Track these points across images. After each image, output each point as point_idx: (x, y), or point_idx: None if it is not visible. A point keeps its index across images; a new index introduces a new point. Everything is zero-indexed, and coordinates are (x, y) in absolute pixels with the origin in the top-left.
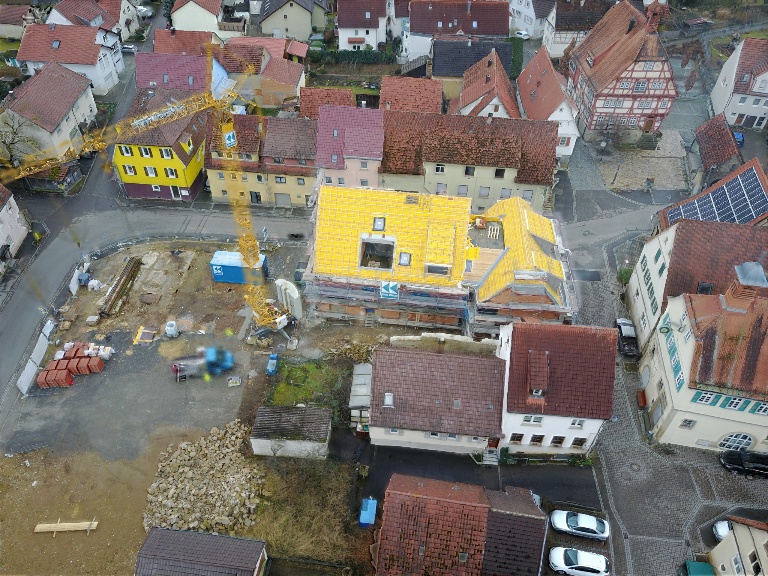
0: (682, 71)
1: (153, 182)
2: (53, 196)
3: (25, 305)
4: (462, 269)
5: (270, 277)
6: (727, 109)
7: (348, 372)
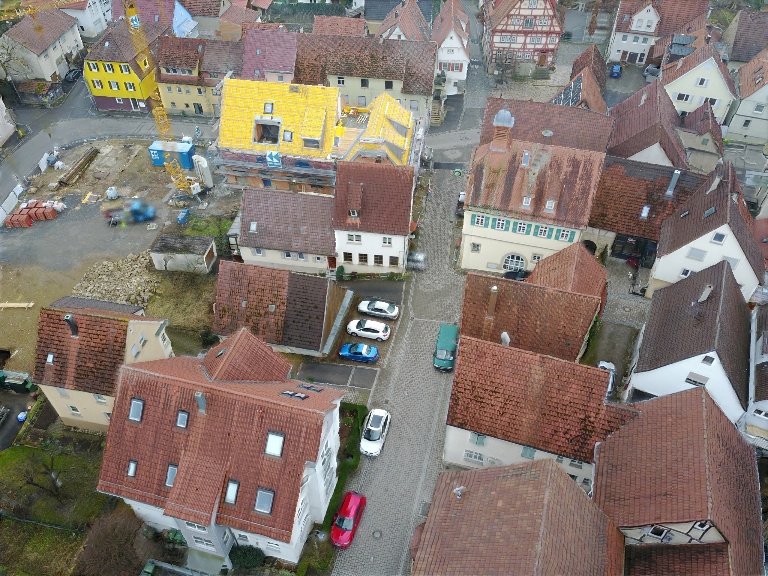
0: (584, 17)
1: (116, 95)
2: (39, 108)
3: (5, 178)
4: (331, 144)
5: None
6: (613, 46)
7: None
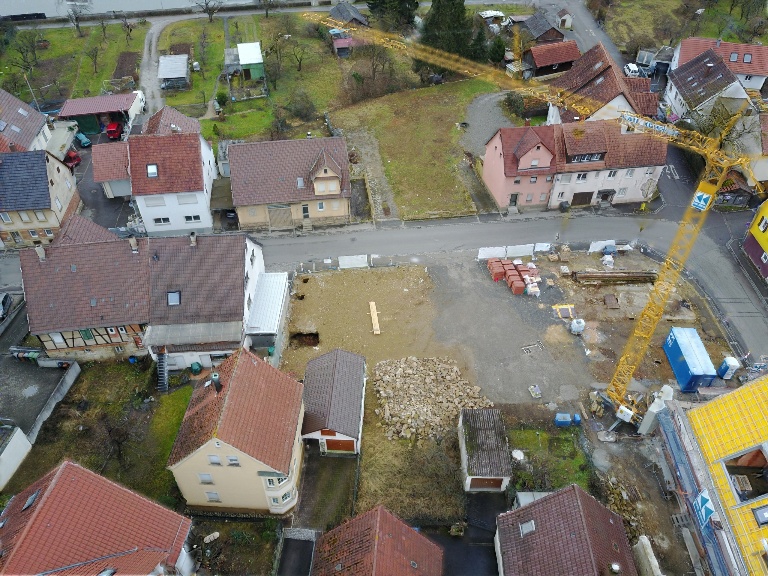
0: None
1: (767, 250)
2: None
3: (565, 229)
4: None
5: (700, 396)
6: None
7: None
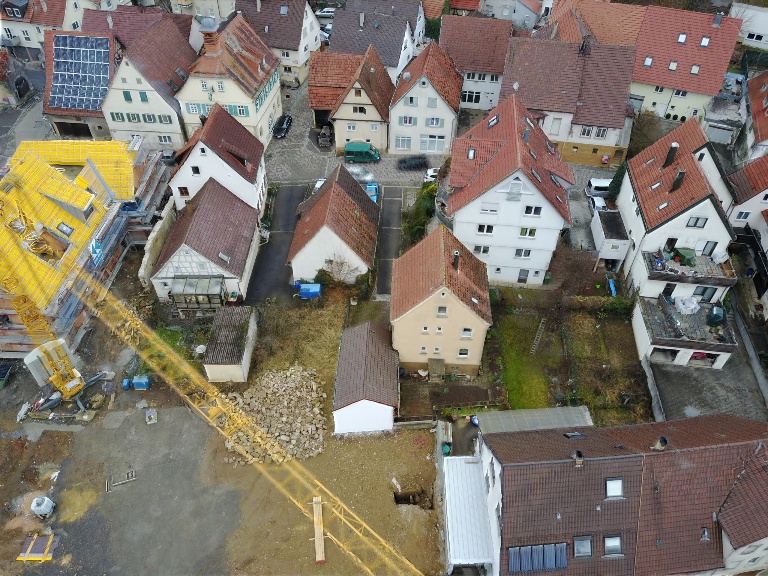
0: None
1: None
2: None
3: None
4: None
5: None
6: None
7: (161, 322)
